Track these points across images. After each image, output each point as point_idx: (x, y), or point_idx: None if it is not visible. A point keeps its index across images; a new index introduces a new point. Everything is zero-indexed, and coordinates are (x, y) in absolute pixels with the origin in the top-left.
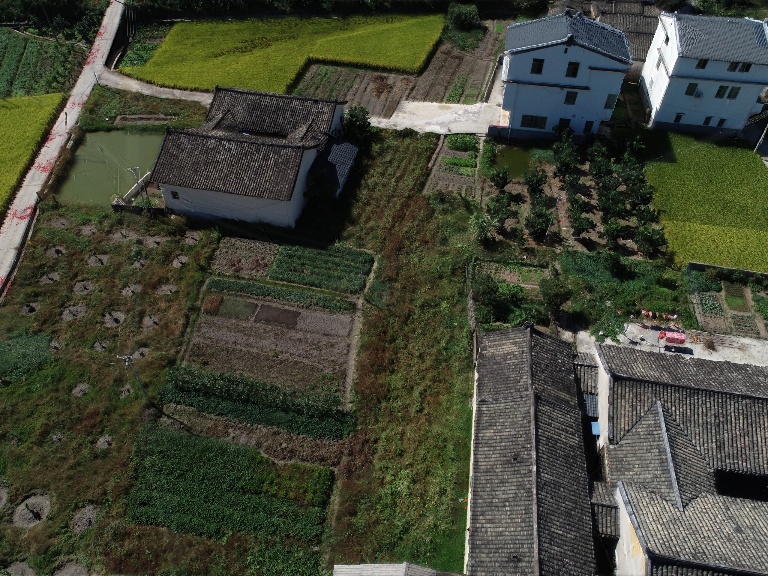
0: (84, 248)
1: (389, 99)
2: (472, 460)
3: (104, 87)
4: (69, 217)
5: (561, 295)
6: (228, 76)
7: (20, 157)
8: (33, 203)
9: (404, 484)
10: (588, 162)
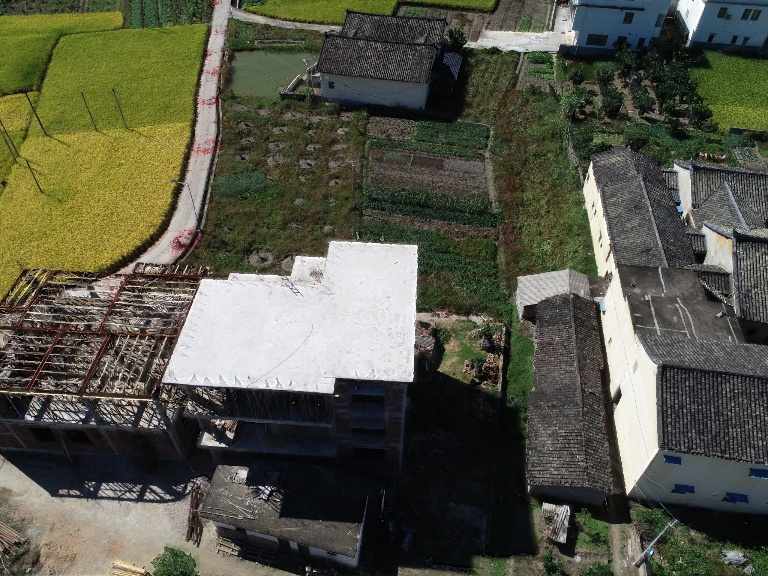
0: (266, 122)
1: (471, 30)
2: (596, 227)
3: (237, 20)
4: (246, 104)
5: (641, 140)
6: (337, 12)
7: (193, 65)
8: (215, 95)
9: (548, 247)
10: (641, 70)
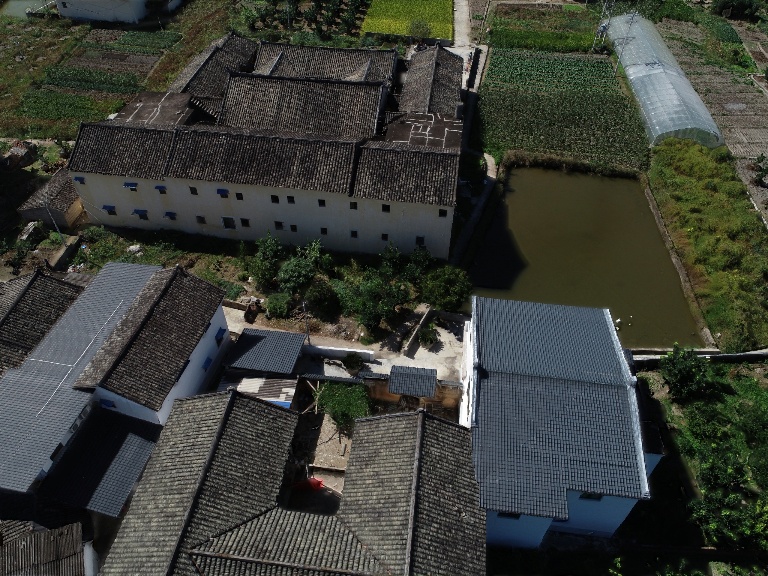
0: (7, 33)
1: None
2: None
3: None
4: None
5: (272, 36)
6: None
7: None
8: None
9: None
10: None
